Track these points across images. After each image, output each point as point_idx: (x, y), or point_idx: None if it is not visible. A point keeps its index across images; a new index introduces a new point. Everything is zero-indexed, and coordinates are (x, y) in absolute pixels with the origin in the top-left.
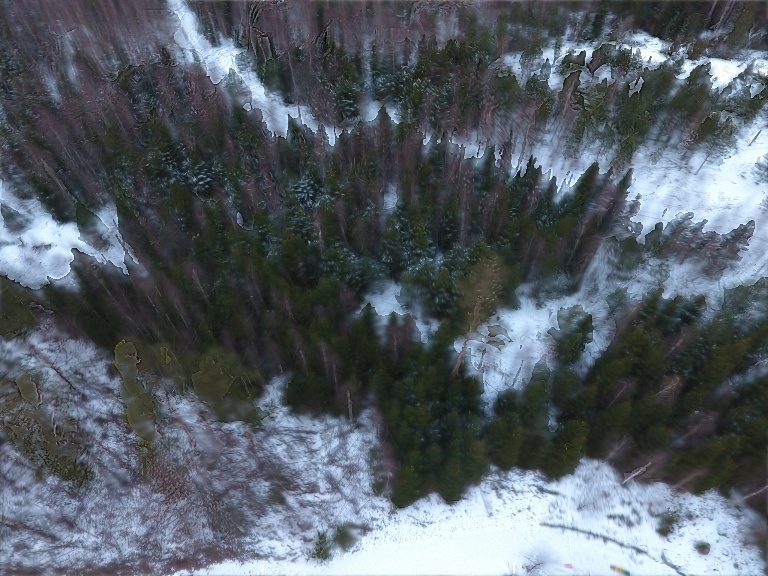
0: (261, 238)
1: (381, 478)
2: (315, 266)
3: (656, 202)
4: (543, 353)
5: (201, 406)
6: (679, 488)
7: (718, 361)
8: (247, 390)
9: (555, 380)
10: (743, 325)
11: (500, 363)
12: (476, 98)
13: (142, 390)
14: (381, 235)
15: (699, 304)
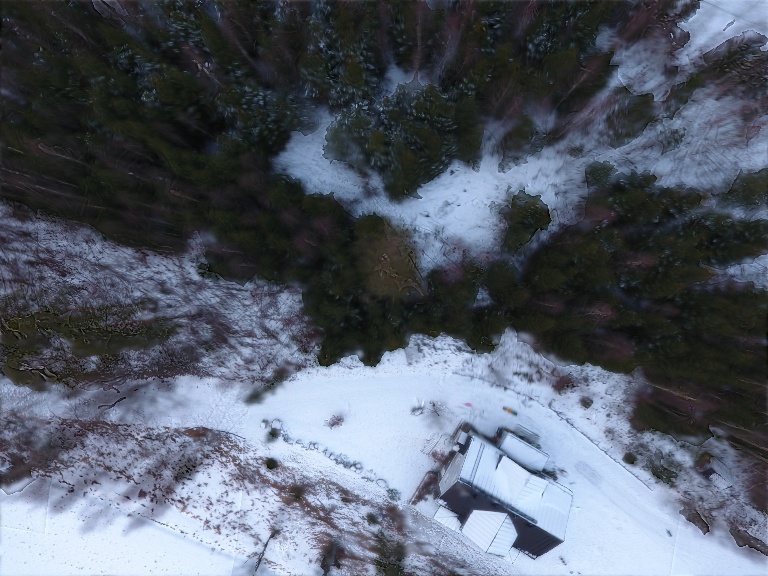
0: (129, 63)
1: (312, 330)
2: (212, 108)
3: None
4: (493, 223)
5: (126, 257)
6: None
7: (671, 284)
8: (166, 251)
9: (490, 273)
10: (731, 231)
11: (442, 231)
12: None
13: (17, 342)
14: (301, 54)
15: (690, 206)
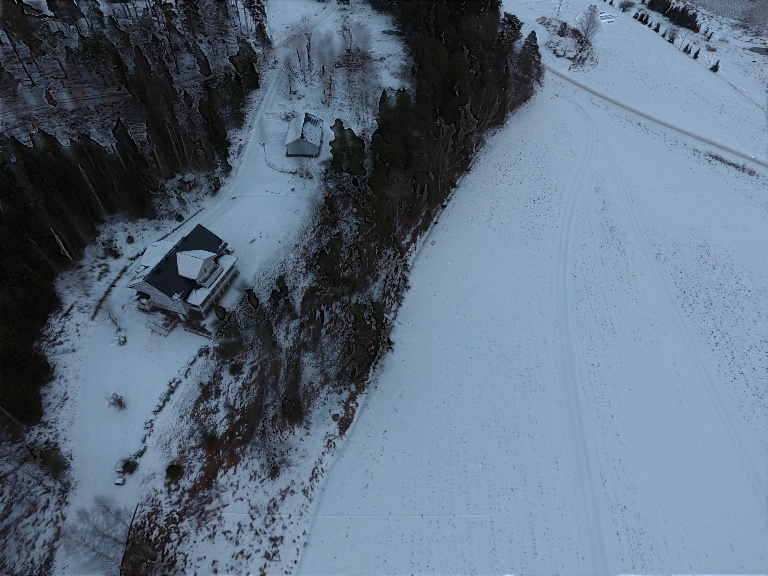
0: None
1: (7, 435)
2: None
3: None
4: None
5: None
6: (91, 240)
7: None
8: None
9: None
10: None
11: None
12: None
13: None
14: None
15: None
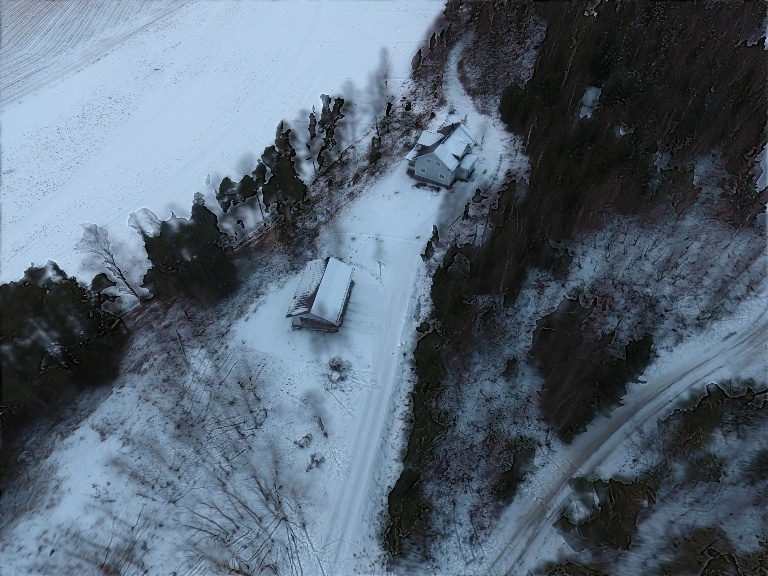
0: None
1: None
2: None
3: None
4: None
5: (528, 67)
6: None
7: None
8: None
9: None
10: None
11: None
12: None
13: None
14: None
15: None
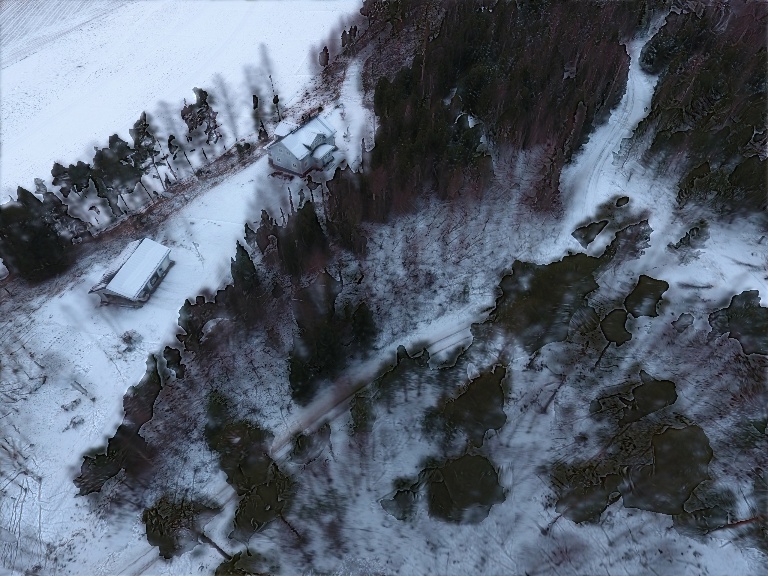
0: None
1: None
2: None
3: (610, 189)
4: None
5: None
6: None
7: None
8: None
9: None
10: (455, 154)
11: None
12: (682, 79)
13: None
14: None
15: None
